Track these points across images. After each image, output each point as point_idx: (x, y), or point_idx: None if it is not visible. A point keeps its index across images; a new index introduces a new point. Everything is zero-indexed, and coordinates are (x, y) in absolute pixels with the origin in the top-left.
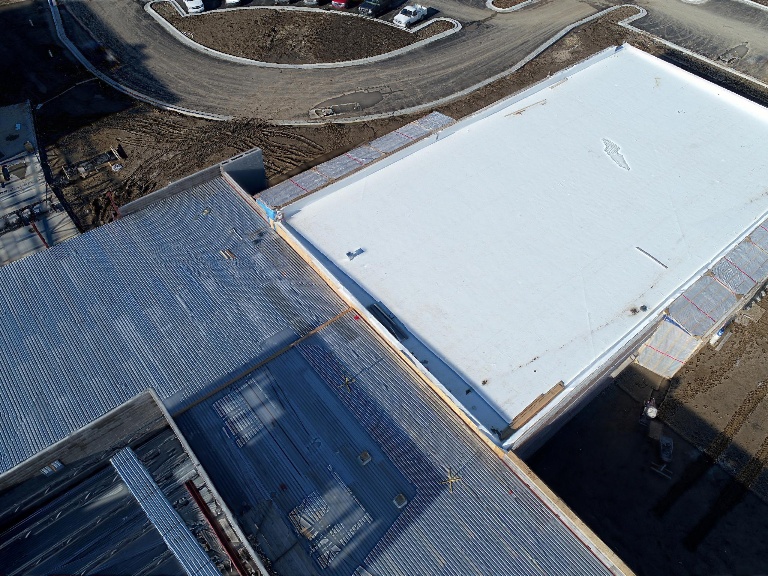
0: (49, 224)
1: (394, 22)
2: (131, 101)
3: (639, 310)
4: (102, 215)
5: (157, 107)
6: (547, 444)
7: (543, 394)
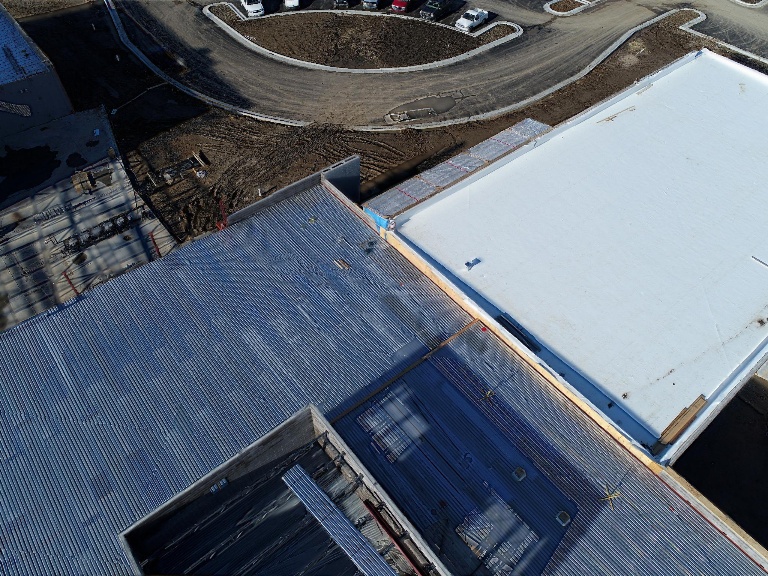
0: (143, 232)
1: (456, 26)
2: (205, 106)
3: (766, 321)
4: (194, 222)
5: (231, 112)
6: None
7: (686, 408)
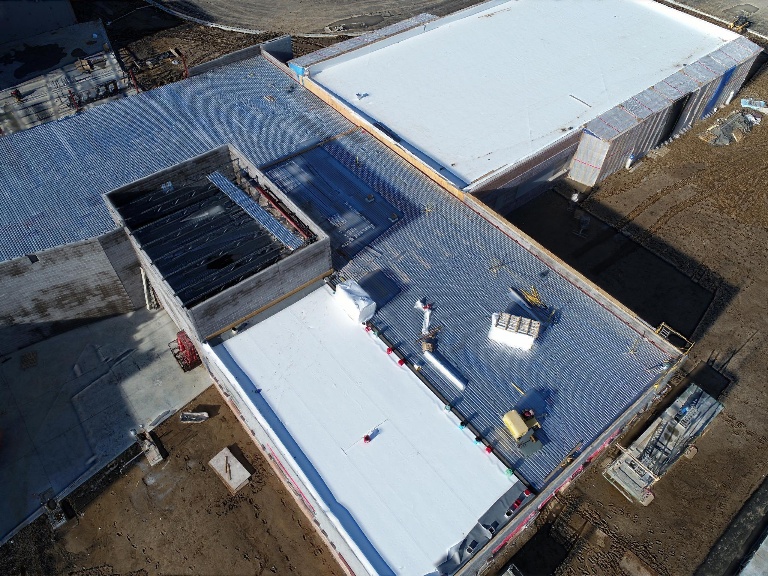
0: None
1: None
2: (181, 21)
3: (567, 129)
4: None
5: (202, 25)
6: None
7: (493, 170)
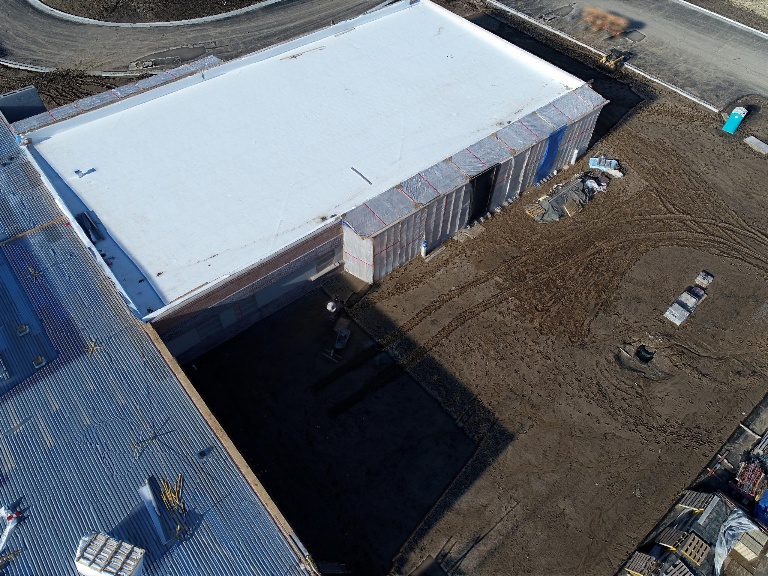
0: None
1: None
2: None
3: (329, 218)
4: None
5: None
6: (238, 336)
7: (207, 283)
